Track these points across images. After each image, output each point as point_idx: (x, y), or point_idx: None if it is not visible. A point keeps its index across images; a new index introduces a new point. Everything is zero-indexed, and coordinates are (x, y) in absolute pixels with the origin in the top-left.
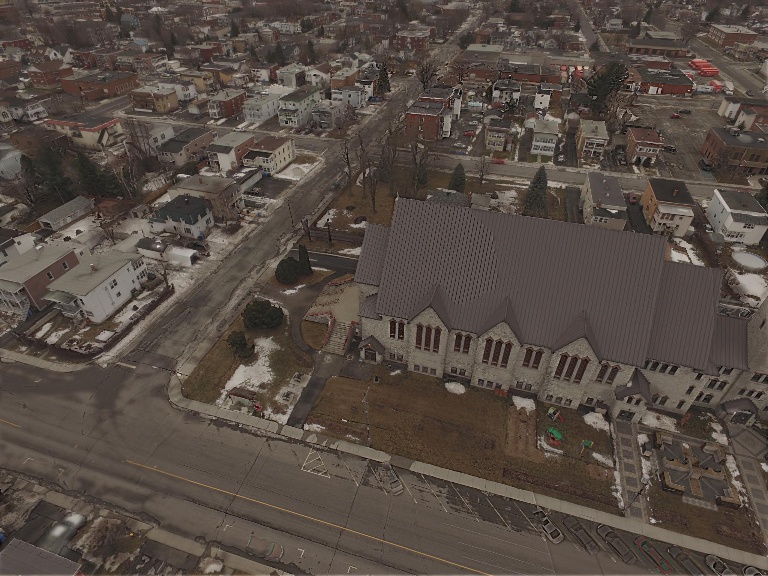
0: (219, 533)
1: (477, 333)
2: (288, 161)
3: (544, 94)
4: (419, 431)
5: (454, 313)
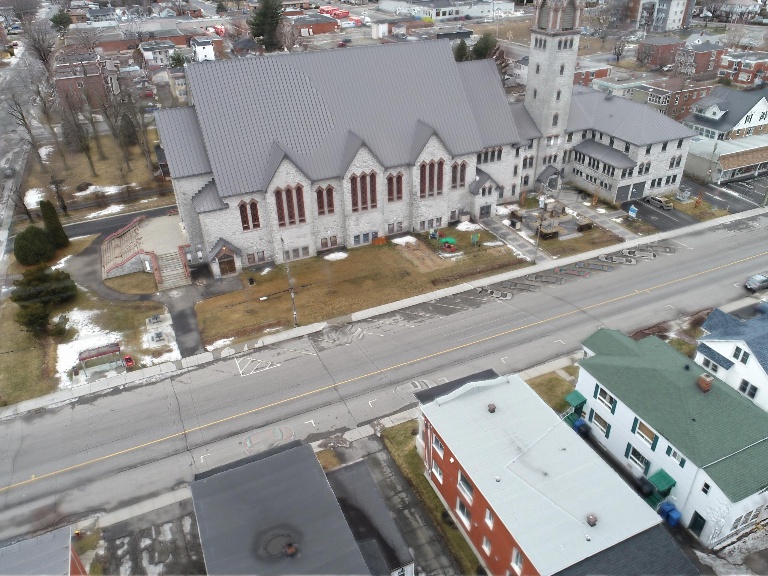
0: (199, 467)
1: (339, 175)
2: None
3: (205, 45)
4: (334, 295)
5: (307, 165)
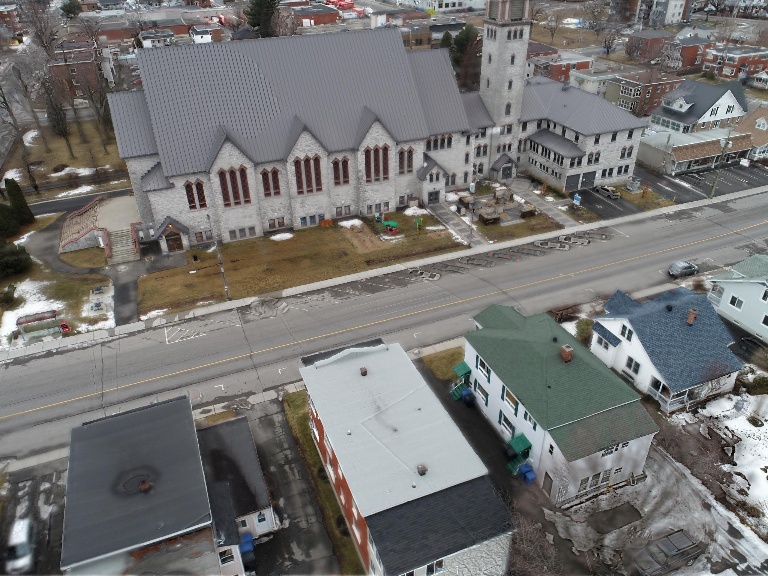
0: None
1: (283, 158)
2: None
3: (203, 35)
4: (271, 272)
5: (251, 148)
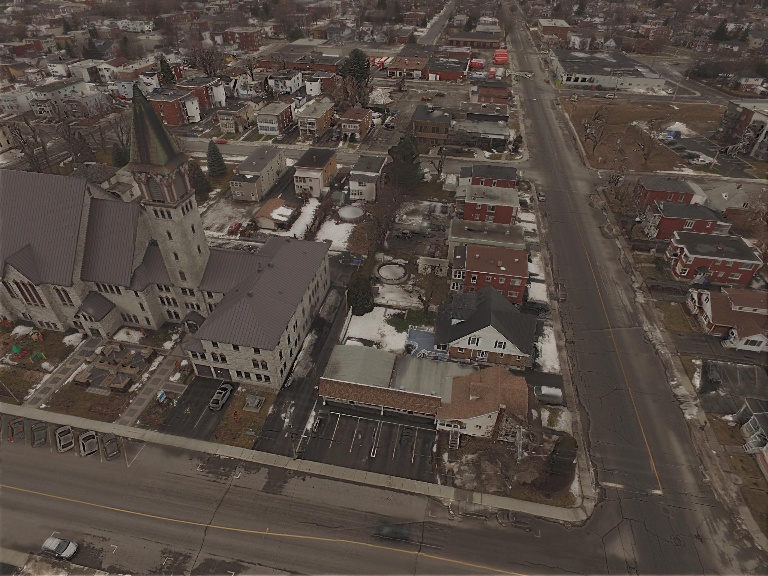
0: None
1: None
2: (8, 147)
3: (312, 81)
4: None
5: None
